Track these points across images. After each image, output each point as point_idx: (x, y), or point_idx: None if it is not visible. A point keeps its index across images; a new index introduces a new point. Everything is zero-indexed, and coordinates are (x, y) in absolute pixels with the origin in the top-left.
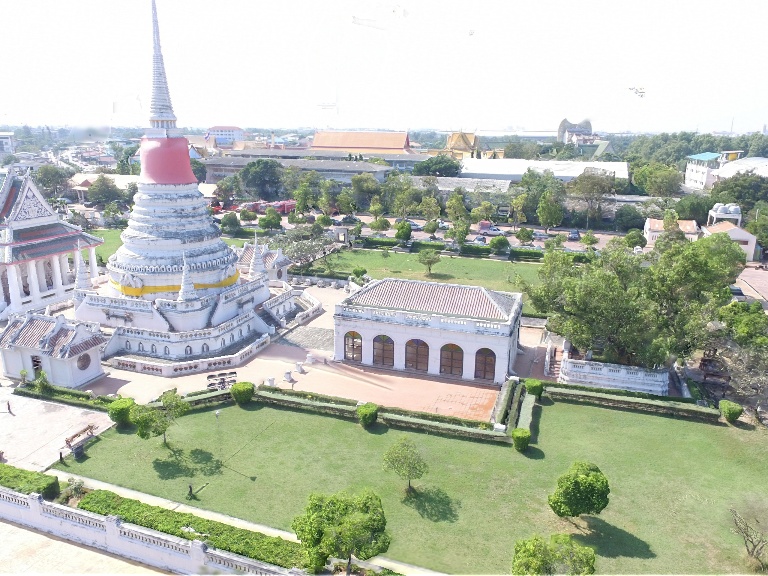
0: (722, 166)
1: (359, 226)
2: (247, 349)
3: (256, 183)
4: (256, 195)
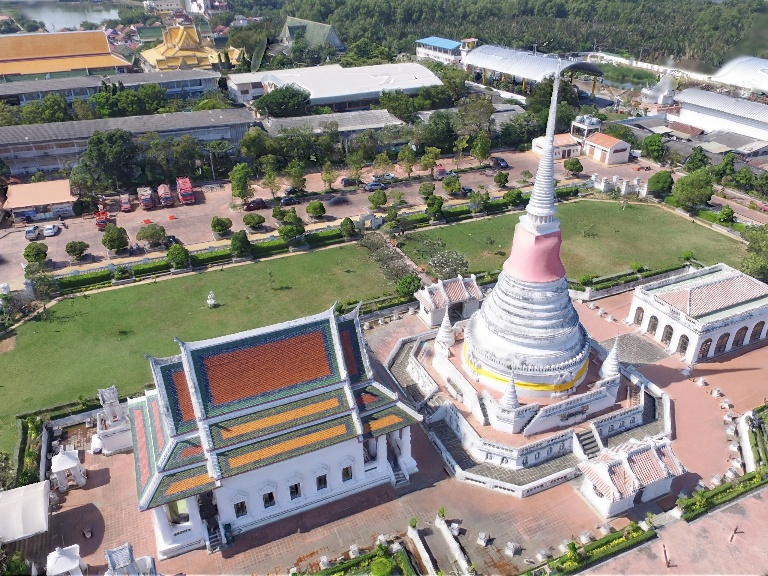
0: (467, 54)
1: None
2: None
3: (119, 166)
4: (105, 179)
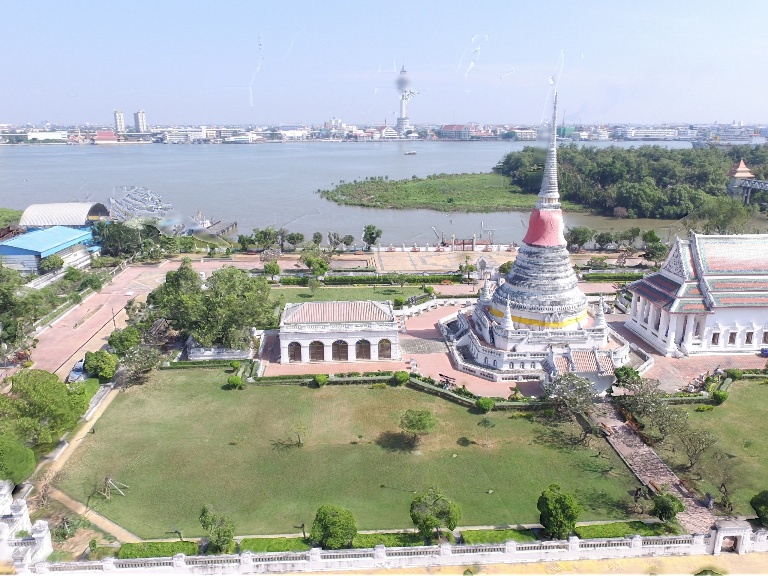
0: None
1: None
2: None
3: None
4: None
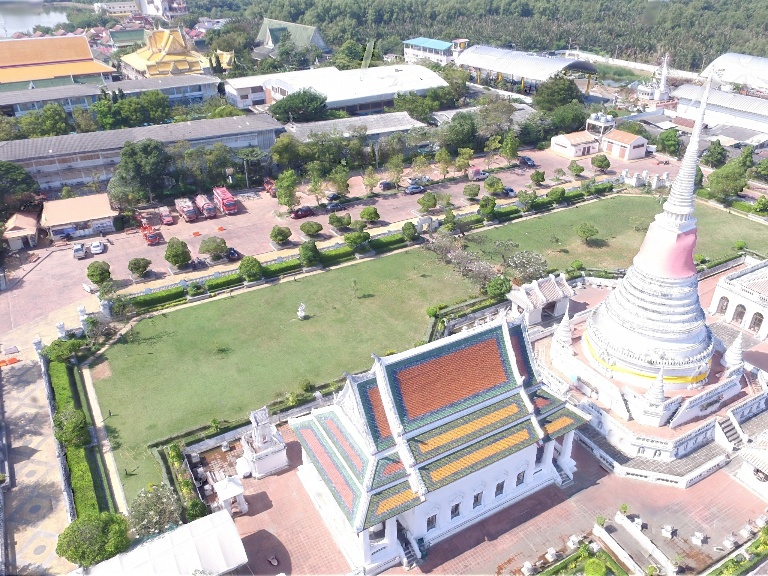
0: (459, 55)
1: None
2: (766, 372)
3: (155, 178)
4: (137, 191)
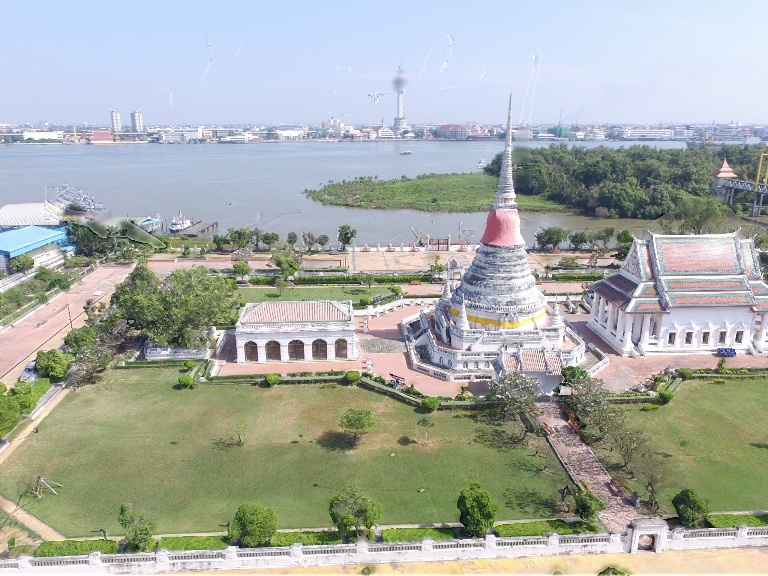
0: None
1: (583, 494)
2: None
3: None
4: None
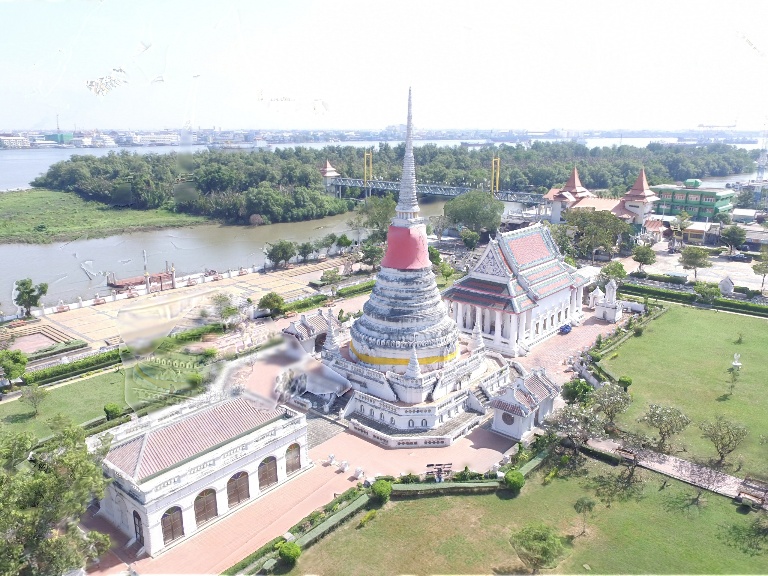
0: None
1: None
2: None
3: None
4: None
